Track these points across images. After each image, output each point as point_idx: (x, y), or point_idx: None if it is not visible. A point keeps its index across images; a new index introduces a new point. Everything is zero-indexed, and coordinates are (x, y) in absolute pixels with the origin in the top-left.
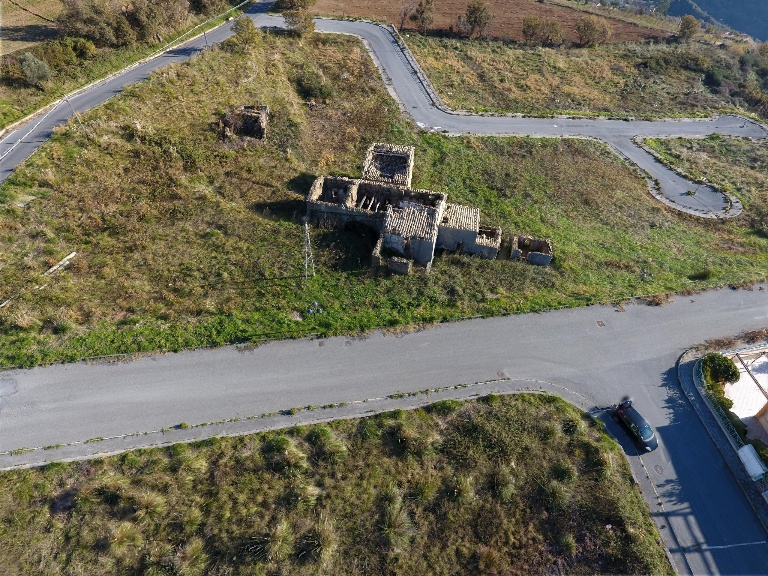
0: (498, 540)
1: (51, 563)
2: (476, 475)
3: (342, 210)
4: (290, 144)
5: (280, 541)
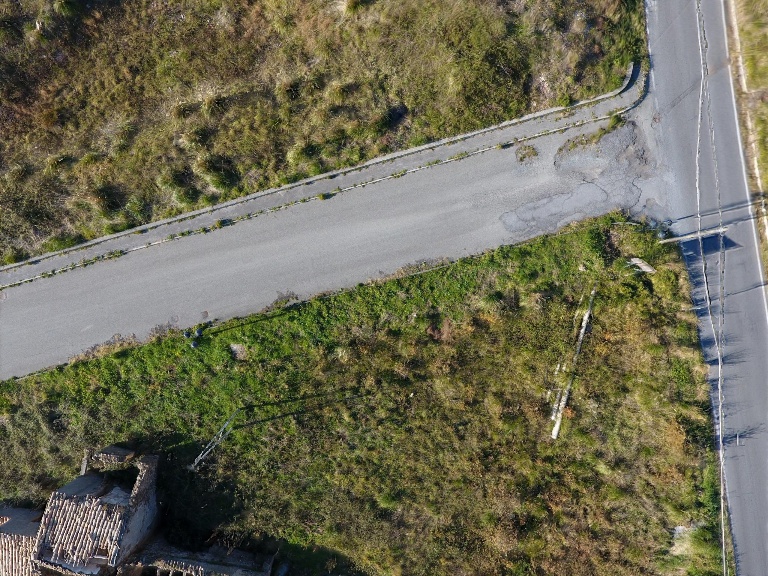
0: (40, 137)
1: (388, 73)
2: (39, 177)
3: (206, 567)
4: None
5: (198, 90)
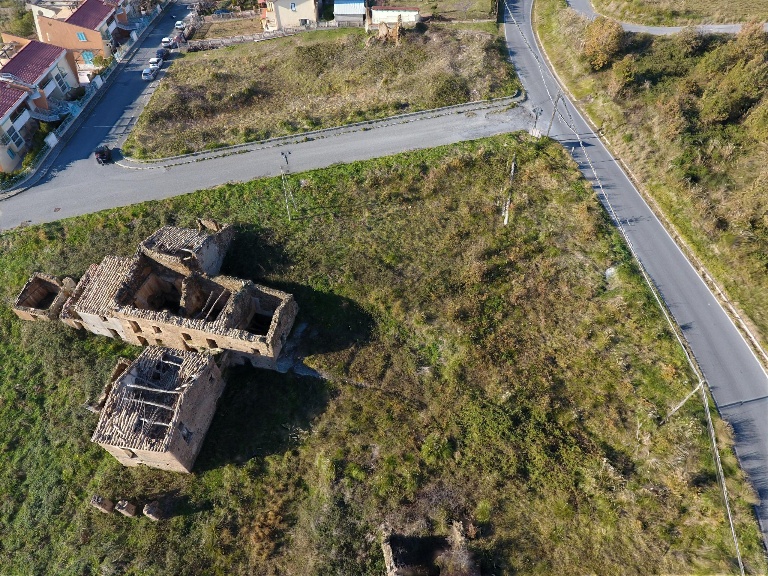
0: None
1: None
2: None
3: None
4: (334, 542)
5: None
